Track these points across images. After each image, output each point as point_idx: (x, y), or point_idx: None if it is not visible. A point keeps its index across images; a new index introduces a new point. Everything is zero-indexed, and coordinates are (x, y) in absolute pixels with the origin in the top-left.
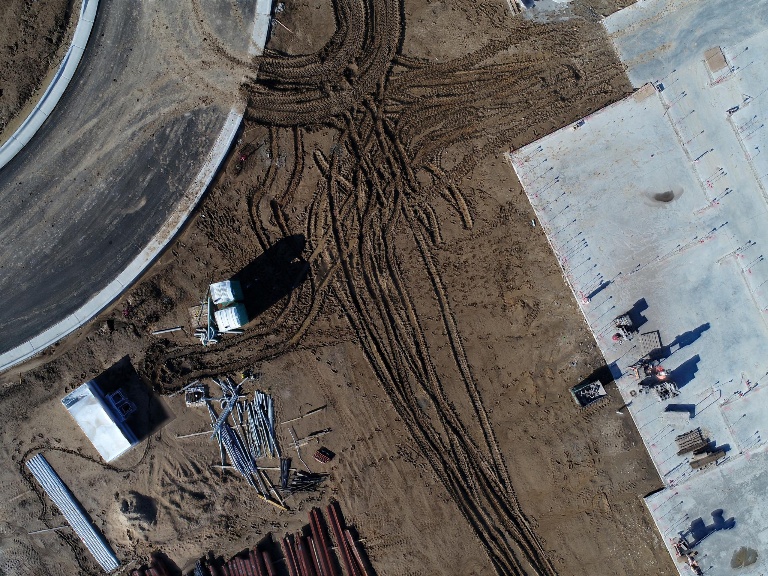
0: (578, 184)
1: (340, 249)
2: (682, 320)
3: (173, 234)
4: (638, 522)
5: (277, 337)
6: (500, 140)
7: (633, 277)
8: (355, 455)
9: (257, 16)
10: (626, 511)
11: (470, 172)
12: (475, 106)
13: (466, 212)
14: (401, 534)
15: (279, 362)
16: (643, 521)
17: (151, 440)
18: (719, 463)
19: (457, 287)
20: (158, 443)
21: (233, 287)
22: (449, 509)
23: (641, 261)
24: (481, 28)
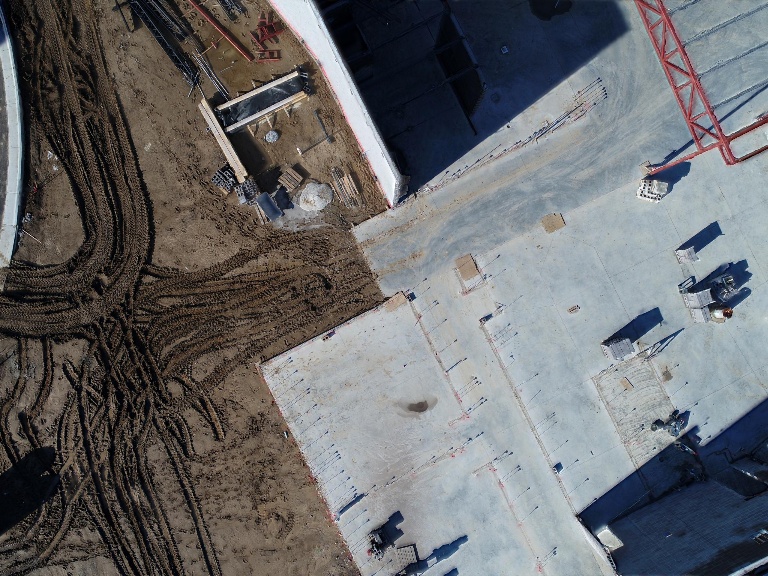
0: (330, 395)
1: (91, 461)
2: (439, 533)
3: None
4: None
5: (27, 552)
6: (251, 350)
7: (388, 490)
8: None
9: (3, 227)
10: None
11: (221, 382)
12: (226, 315)
13: (218, 423)
14: None
15: None
16: None
17: None
18: None
19: (211, 499)
20: None
21: None
22: None
23: (396, 473)
24: (231, 237)
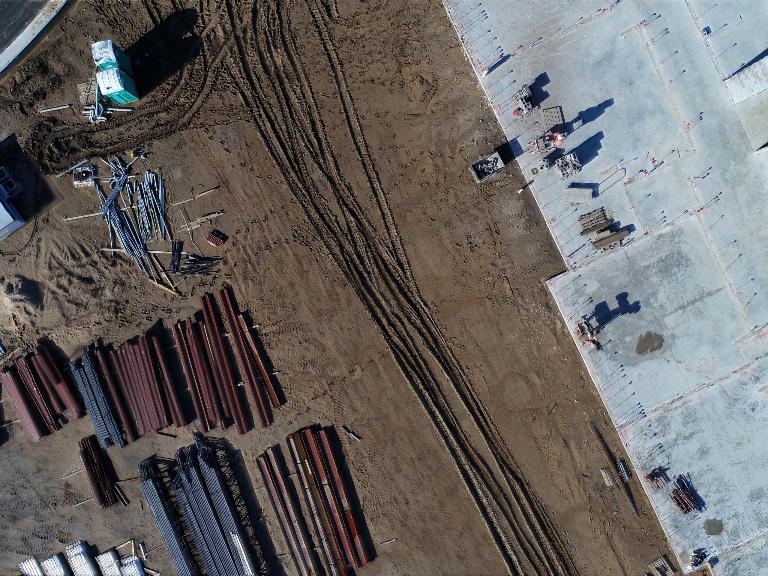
0: None
1: (234, 24)
2: (585, 95)
3: (60, 6)
4: (541, 307)
5: (168, 115)
6: None
7: (534, 50)
8: (249, 238)
9: None
10: (528, 295)
11: None
12: None
13: None
14: (297, 321)
15: (170, 141)
16: (546, 306)
17: (38, 222)
18: (624, 244)
19: (354, 63)
20: (45, 225)
21: (117, 50)
22: (346, 294)
23: (543, 34)
24: None
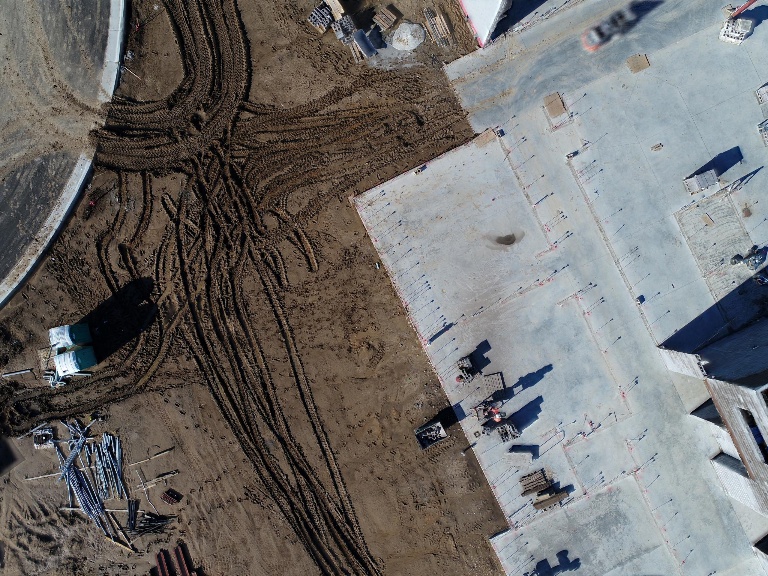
0: (421, 228)
1: (188, 291)
2: (525, 362)
3: (22, 277)
4: (484, 563)
5: (125, 379)
6: (344, 184)
7: (476, 319)
8: (203, 497)
9: (106, 63)
10: (472, 552)
11: (315, 216)
12: (320, 151)
13: (312, 255)
14: (249, 575)
15: (127, 404)
16: (489, 562)
17: None
18: (564, 504)
19: (304, 329)
20: (6, 485)
21: (74, 331)
22: (297, 551)
23: (483, 303)
24: (325, 75)
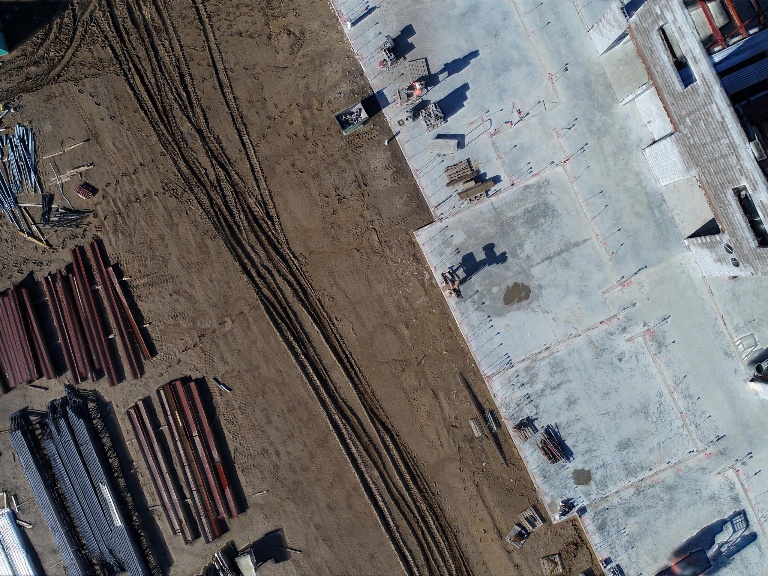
0: None
1: None
2: (451, 47)
3: None
4: (409, 258)
5: (38, 69)
6: None
7: (400, 2)
8: (119, 191)
9: None
10: (396, 247)
11: None
12: None
13: None
14: (167, 273)
15: (40, 95)
16: (414, 257)
17: None
18: (490, 195)
19: (222, 16)
20: None
21: None
22: (216, 247)
23: None
24: None
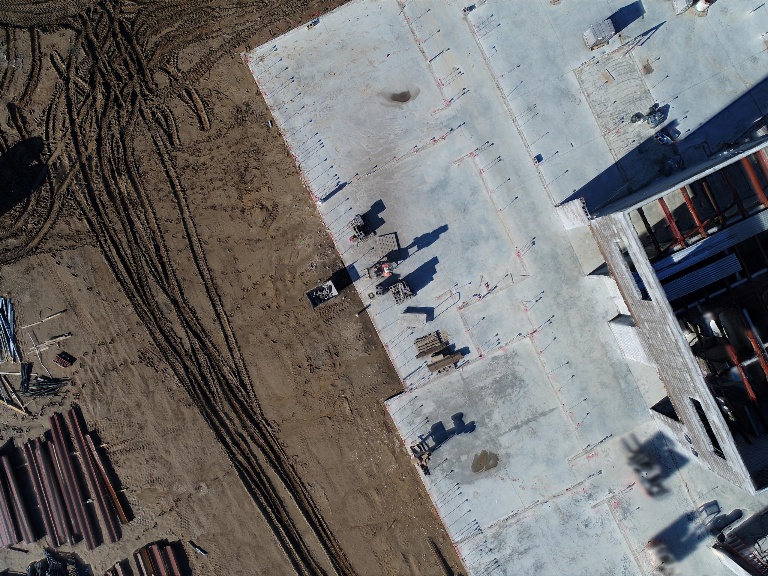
0: (314, 84)
1: (79, 152)
2: (420, 222)
3: None
4: (379, 426)
5: (16, 241)
6: (236, 40)
7: (370, 178)
8: (96, 360)
9: None
10: (367, 415)
11: (207, 73)
12: (211, 6)
13: (204, 114)
14: (143, 439)
15: (19, 266)
16: (384, 425)
17: None
18: (459, 366)
19: (196, 190)
20: None
21: None
22: (191, 414)
23: (378, 162)
24: None
